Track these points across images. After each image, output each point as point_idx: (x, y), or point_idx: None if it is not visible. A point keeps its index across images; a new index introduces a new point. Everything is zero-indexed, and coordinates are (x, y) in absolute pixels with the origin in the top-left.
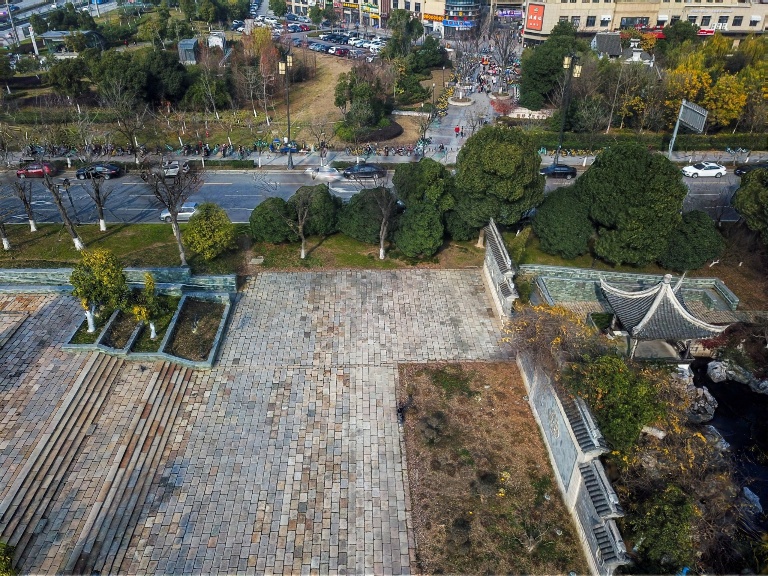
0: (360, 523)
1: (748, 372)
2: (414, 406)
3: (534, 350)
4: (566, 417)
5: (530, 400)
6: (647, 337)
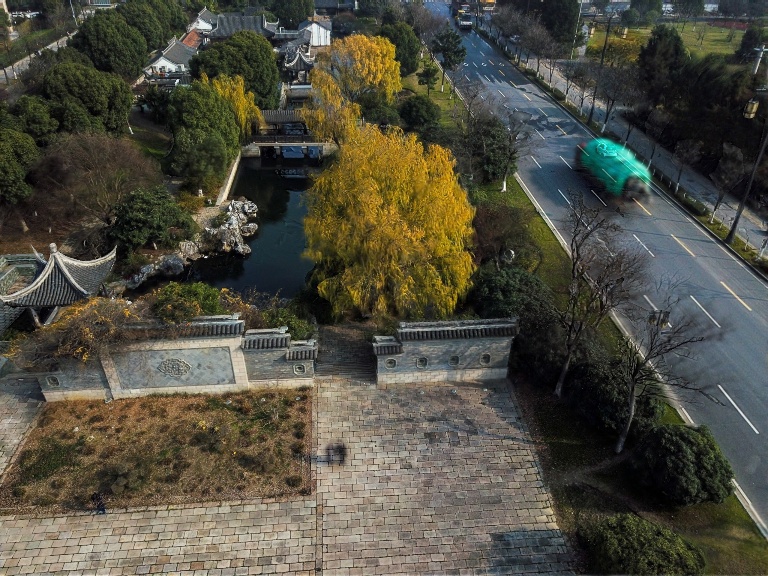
0: (227, 547)
1: (120, 281)
2: (75, 498)
3: (115, 338)
4: (193, 343)
5: (118, 394)
6: (94, 294)
